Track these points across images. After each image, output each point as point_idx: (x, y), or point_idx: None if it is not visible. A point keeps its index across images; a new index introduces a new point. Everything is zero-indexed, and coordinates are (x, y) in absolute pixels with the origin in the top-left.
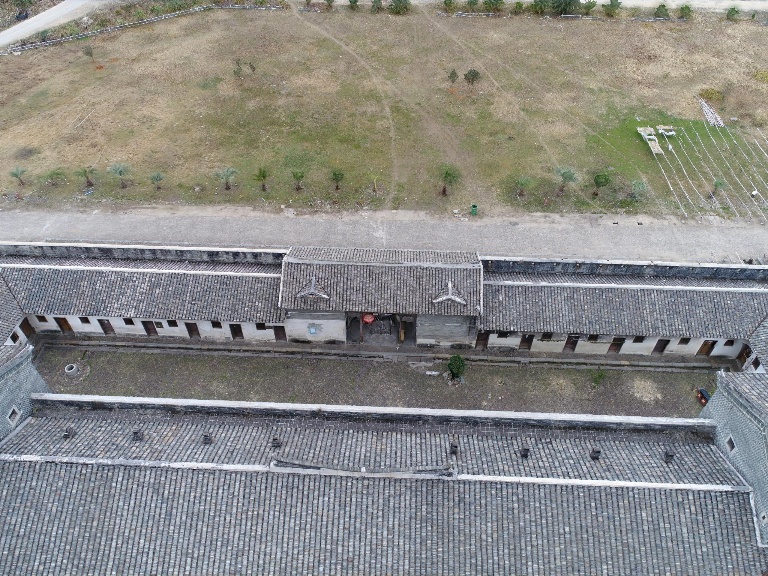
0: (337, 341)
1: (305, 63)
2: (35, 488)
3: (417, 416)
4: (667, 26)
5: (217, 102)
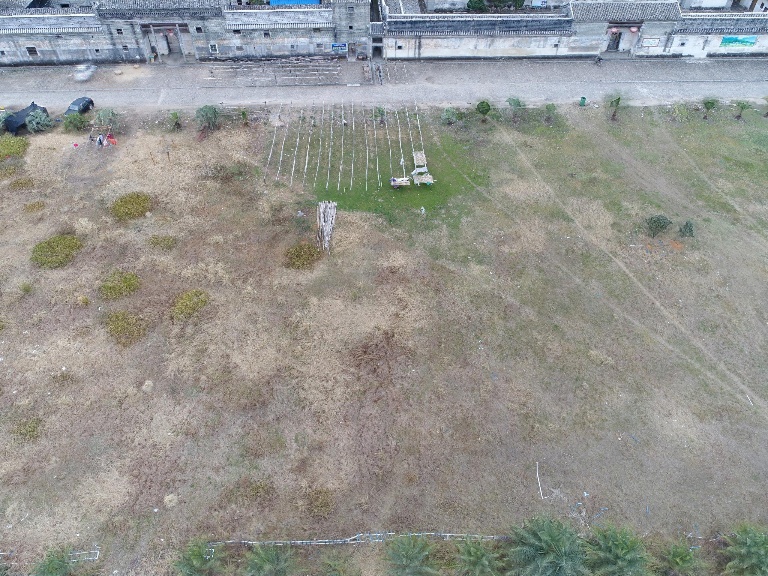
0: None
1: None
2: None
3: None
4: (270, 512)
5: None
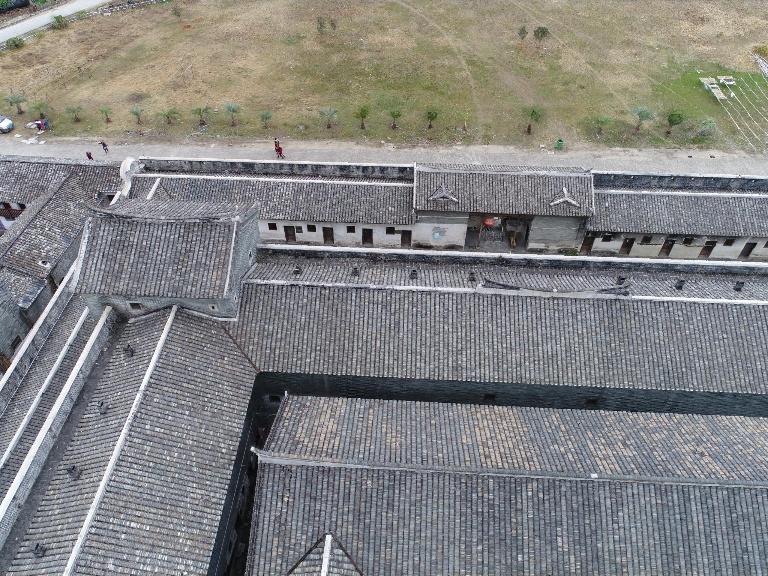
0: (456, 246)
1: (379, 23)
2: (284, 305)
3: (581, 263)
4: None
5: (303, 56)
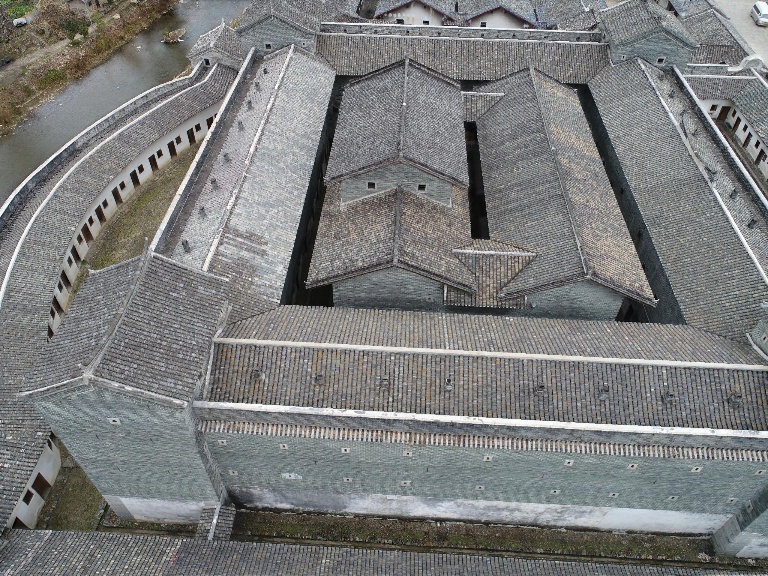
0: None
1: None
2: None
3: None
4: None
5: None
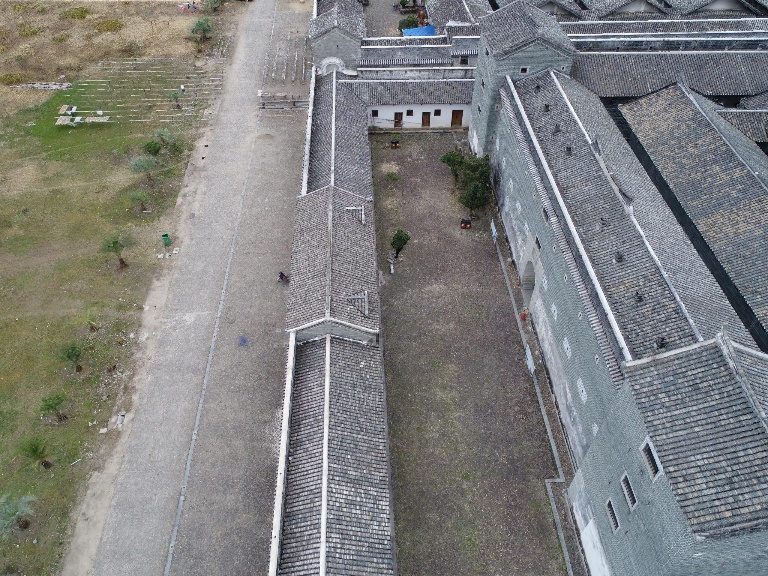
0: None
1: None
2: None
3: None
4: None
5: None
